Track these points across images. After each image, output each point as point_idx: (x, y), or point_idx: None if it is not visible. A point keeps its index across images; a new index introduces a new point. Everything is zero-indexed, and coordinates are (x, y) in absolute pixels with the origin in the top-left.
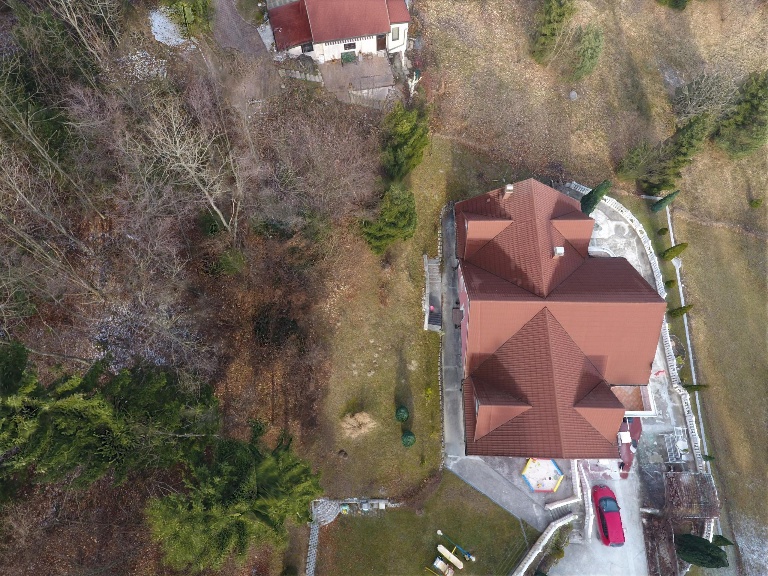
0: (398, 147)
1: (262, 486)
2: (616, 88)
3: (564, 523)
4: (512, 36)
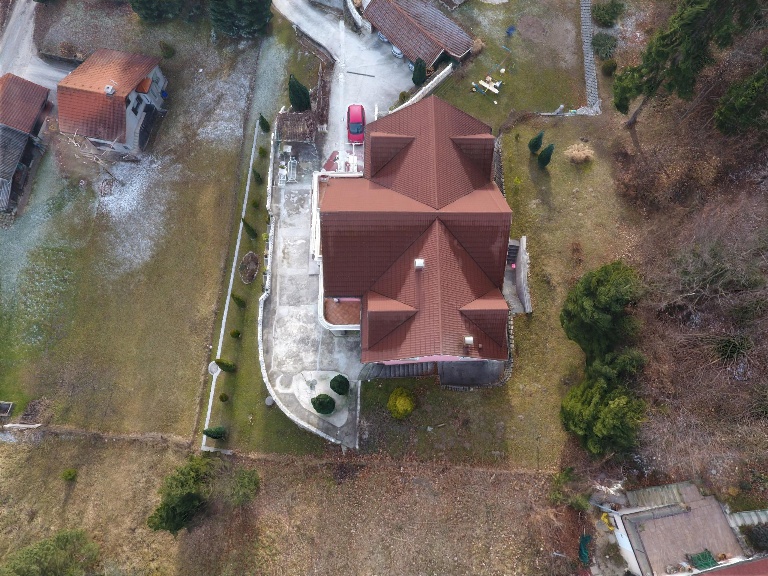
0: (612, 388)
1: (706, 11)
2: None
3: (402, 105)
4: None
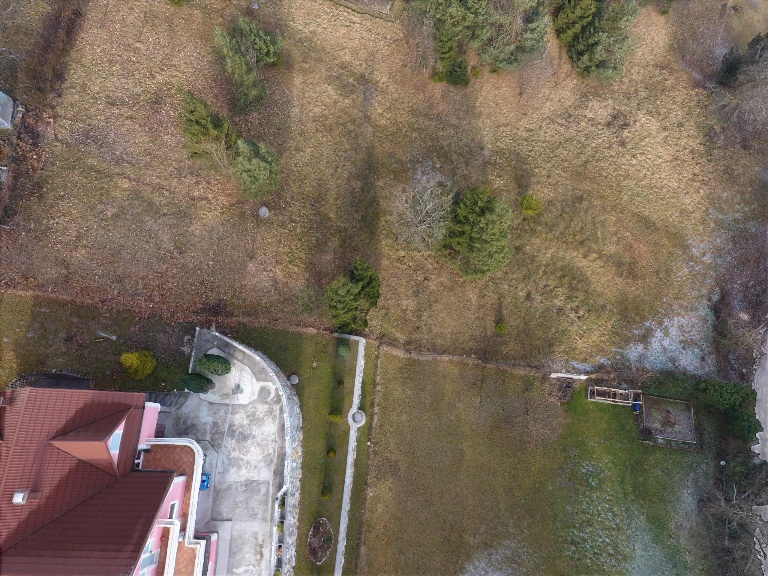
0: None
1: None
2: (338, 194)
3: None
4: (189, 142)
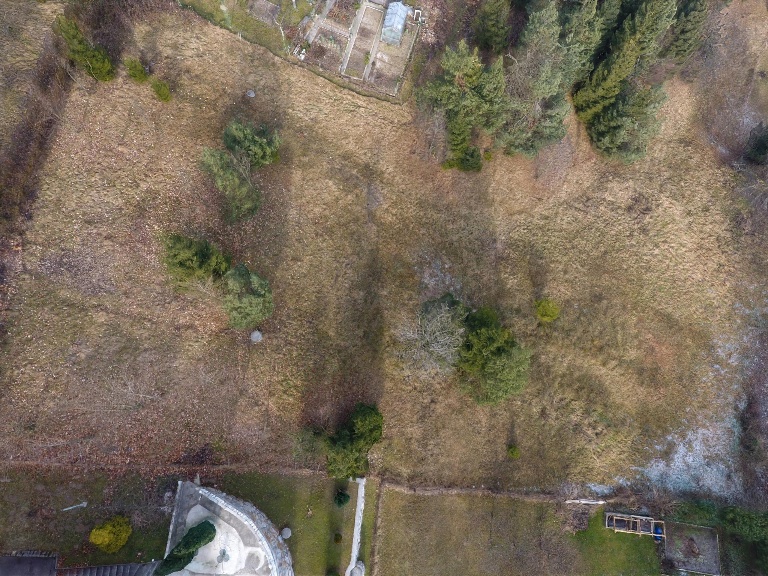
0: None
1: None
2: (338, 308)
3: None
4: None
